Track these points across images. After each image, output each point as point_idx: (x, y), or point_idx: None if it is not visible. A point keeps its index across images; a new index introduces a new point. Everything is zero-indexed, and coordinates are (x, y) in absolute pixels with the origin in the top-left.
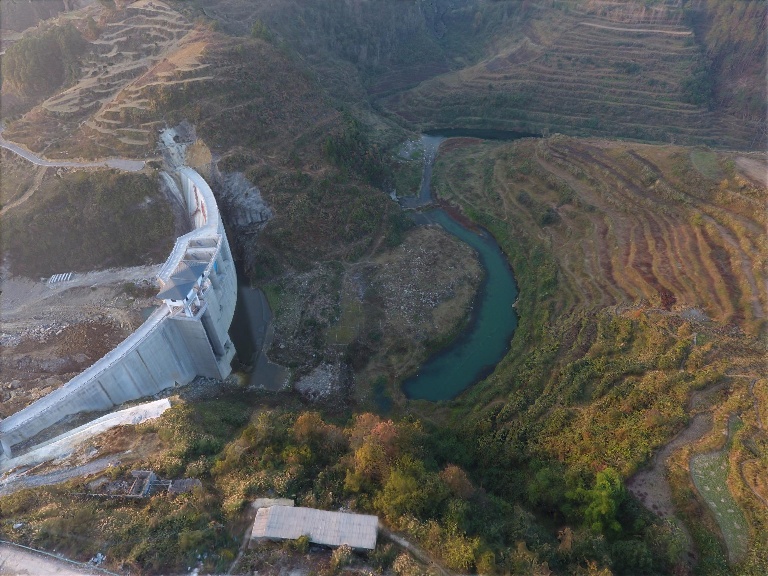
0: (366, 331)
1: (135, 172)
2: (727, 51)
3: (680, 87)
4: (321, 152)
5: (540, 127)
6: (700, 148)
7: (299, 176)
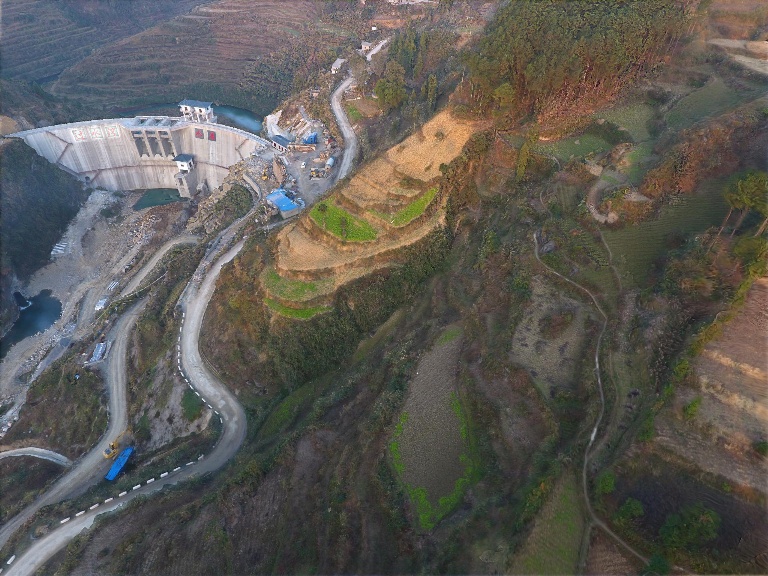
0: None
1: (5, 142)
2: None
3: (69, 20)
4: (40, 98)
5: (37, 73)
6: (164, 22)
7: None
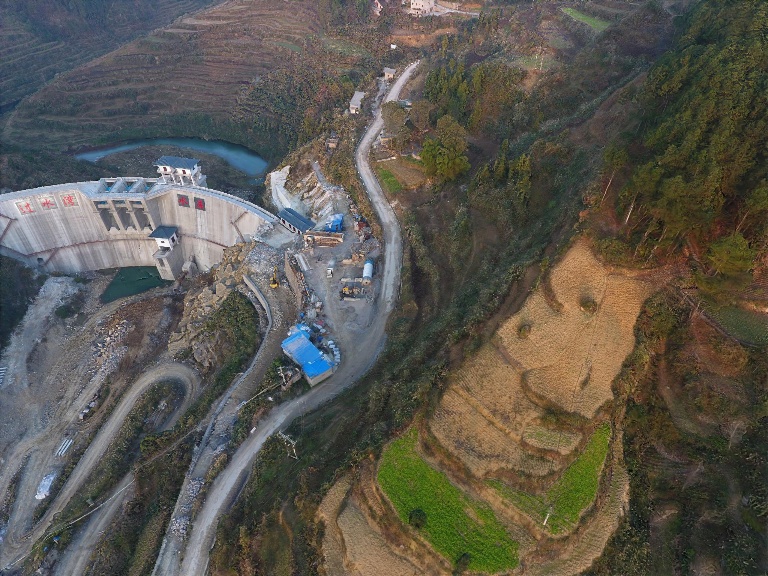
0: (208, 177)
1: None
2: (20, 2)
3: (31, 34)
4: None
5: None
6: (141, 37)
7: (14, 163)
